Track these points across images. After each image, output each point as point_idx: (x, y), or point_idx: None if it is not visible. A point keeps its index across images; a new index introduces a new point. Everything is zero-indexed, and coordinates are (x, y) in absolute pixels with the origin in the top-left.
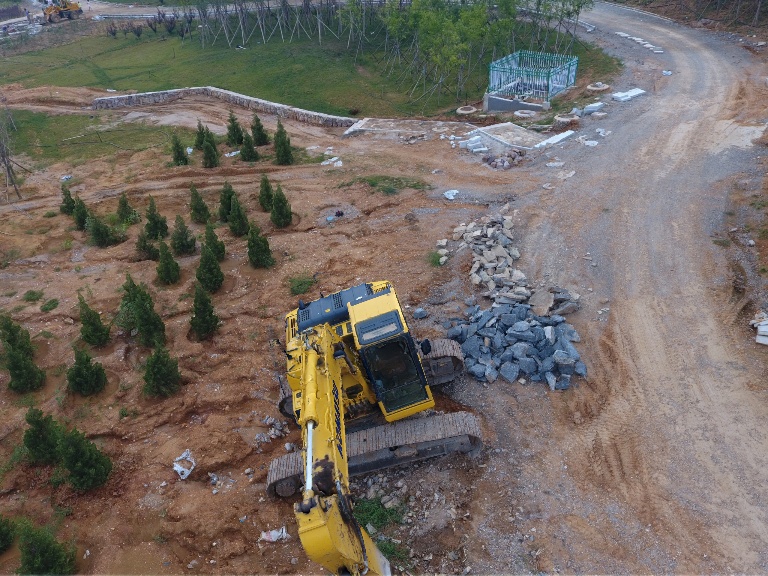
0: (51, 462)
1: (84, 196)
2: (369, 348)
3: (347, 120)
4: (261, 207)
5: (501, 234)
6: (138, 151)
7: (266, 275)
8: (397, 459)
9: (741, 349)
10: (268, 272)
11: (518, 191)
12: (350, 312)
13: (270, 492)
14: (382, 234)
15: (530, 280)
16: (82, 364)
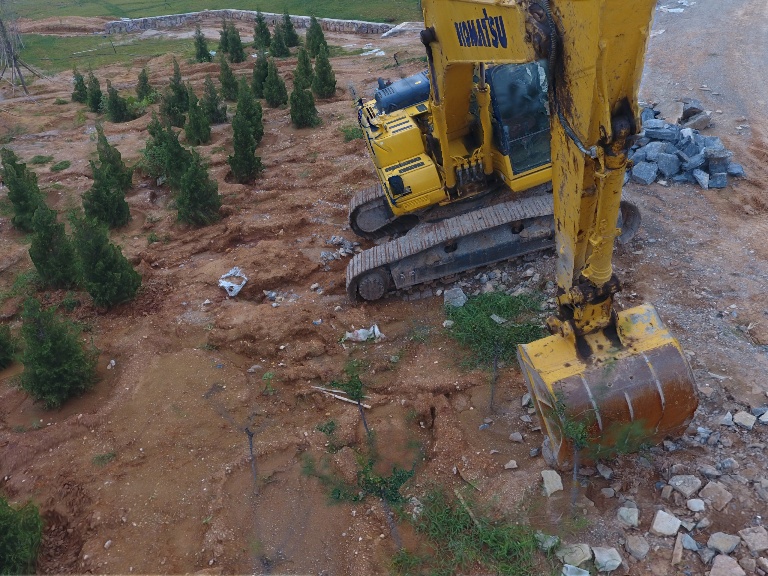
0: (63, 286)
1: None
2: None
3: (384, 25)
4: None
5: None
6: (156, 56)
7: (312, 132)
8: (523, 244)
9: None
10: (314, 130)
11: None
12: None
13: (351, 294)
14: None
15: None
16: (101, 185)
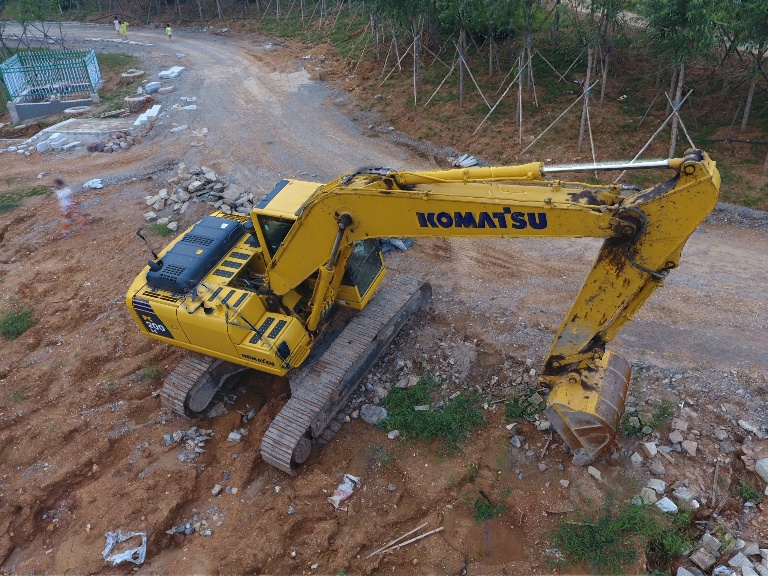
0: None
1: None
2: None
3: None
4: None
5: (220, 177)
6: None
7: None
8: (382, 345)
9: None
10: None
11: (172, 155)
12: (271, 212)
13: None
14: (57, 241)
15: None
16: None
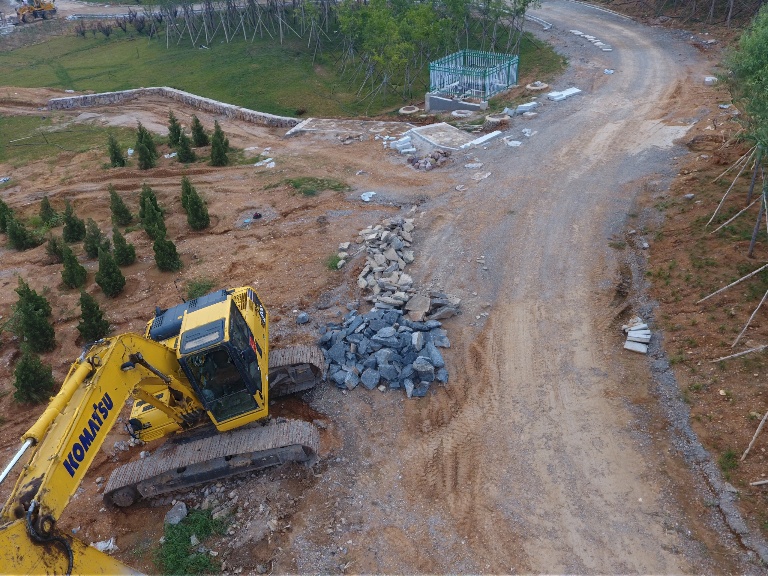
0: None
1: (17, 198)
2: (211, 356)
3: (291, 120)
4: (184, 209)
5: (396, 237)
6: (80, 152)
7: (170, 279)
8: (232, 469)
9: (607, 355)
10: (173, 276)
11: (431, 193)
12: (183, 320)
13: (108, 502)
14: (291, 237)
15: (417, 284)
16: None
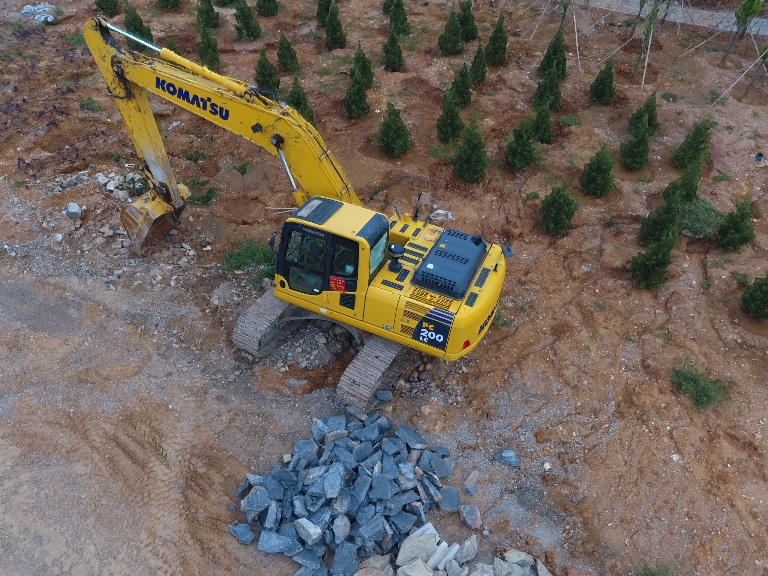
0: None
1: None
2: None
3: None
4: None
5: None
6: None
7: (767, 372)
8: None
9: None
10: None
11: None
12: None
13: None
14: None
15: None
16: None
